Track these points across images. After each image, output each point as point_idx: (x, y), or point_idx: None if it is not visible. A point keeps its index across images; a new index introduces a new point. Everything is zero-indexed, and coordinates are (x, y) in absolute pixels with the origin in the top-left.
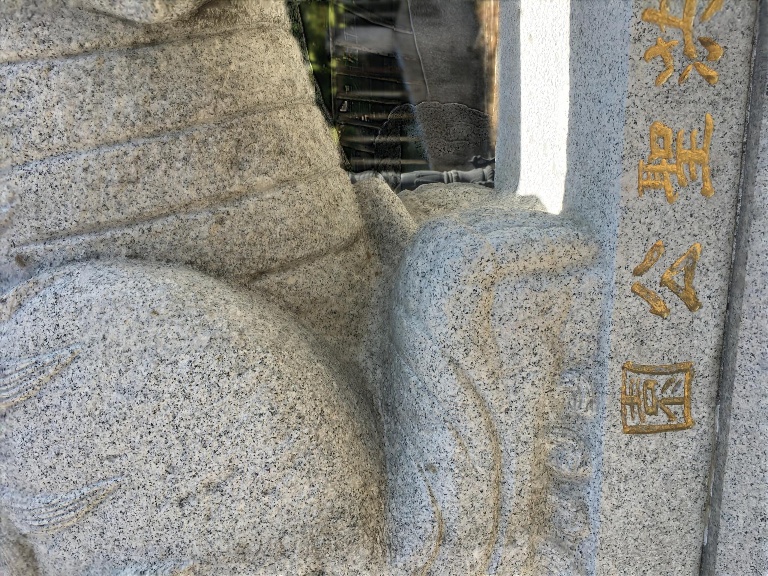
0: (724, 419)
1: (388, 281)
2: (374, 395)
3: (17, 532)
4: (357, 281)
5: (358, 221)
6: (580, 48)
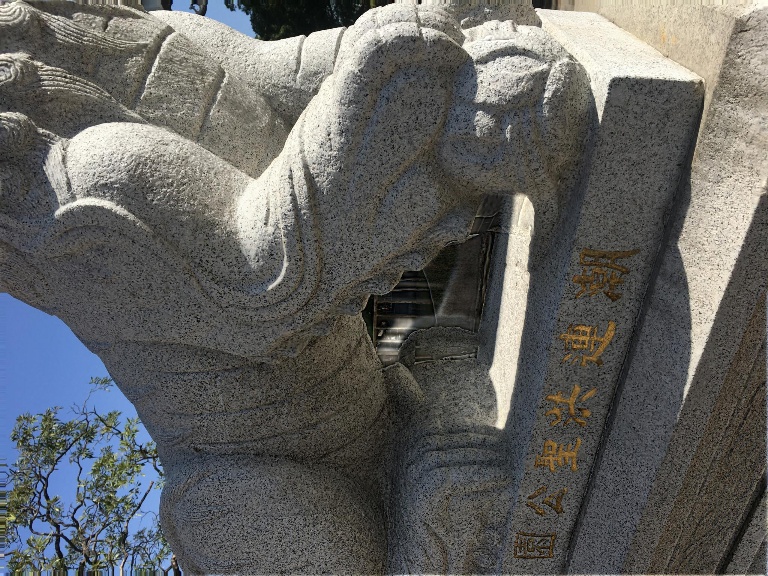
0: (569, 558)
1: (400, 432)
2: (385, 503)
3: (197, 567)
4: (381, 435)
5: (384, 396)
6: (521, 368)
